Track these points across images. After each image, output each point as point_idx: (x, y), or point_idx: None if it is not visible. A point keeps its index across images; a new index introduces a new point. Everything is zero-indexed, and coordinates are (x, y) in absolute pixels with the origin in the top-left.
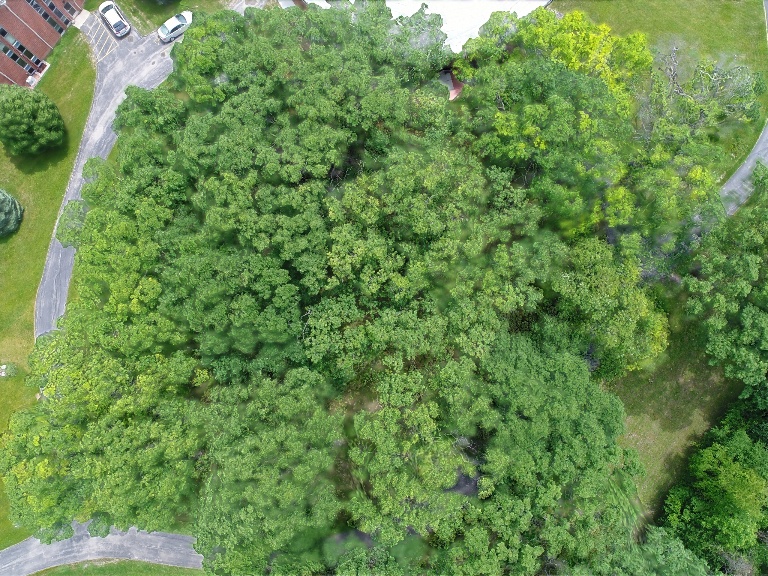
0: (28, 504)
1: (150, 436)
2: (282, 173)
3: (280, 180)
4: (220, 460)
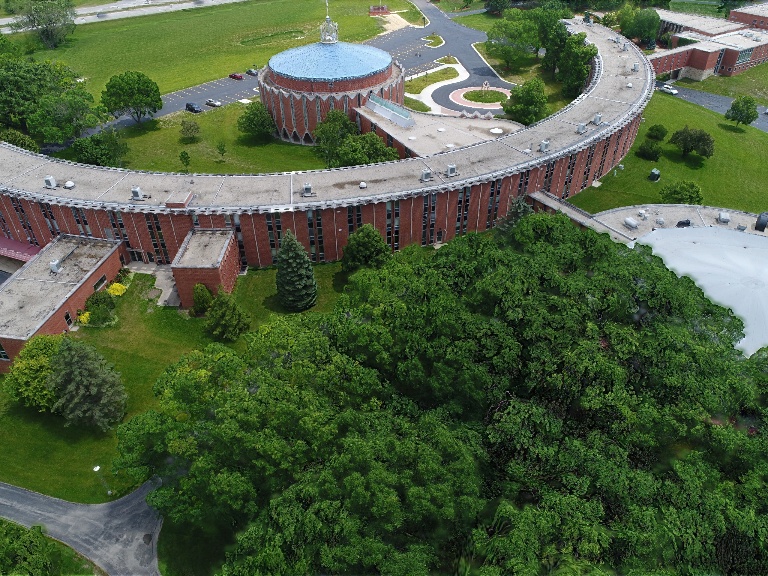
0: (163, 395)
1: (305, 397)
2: (563, 287)
3: (557, 292)
4: (348, 444)
